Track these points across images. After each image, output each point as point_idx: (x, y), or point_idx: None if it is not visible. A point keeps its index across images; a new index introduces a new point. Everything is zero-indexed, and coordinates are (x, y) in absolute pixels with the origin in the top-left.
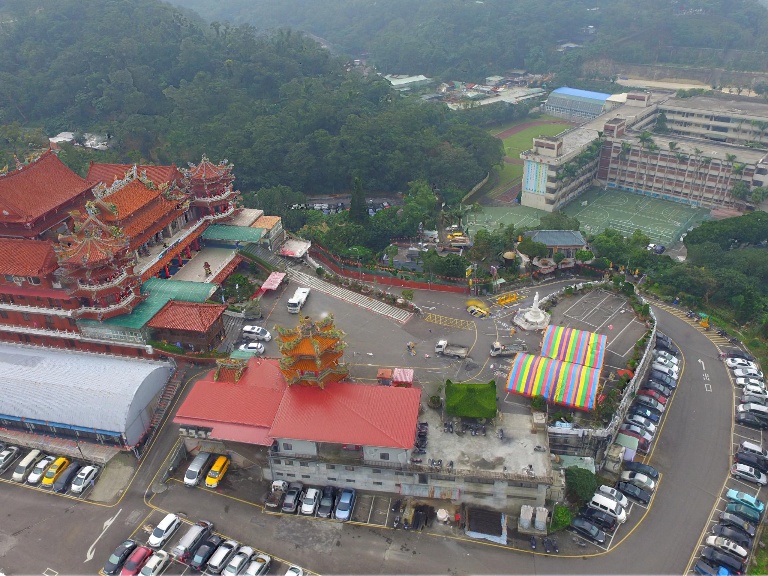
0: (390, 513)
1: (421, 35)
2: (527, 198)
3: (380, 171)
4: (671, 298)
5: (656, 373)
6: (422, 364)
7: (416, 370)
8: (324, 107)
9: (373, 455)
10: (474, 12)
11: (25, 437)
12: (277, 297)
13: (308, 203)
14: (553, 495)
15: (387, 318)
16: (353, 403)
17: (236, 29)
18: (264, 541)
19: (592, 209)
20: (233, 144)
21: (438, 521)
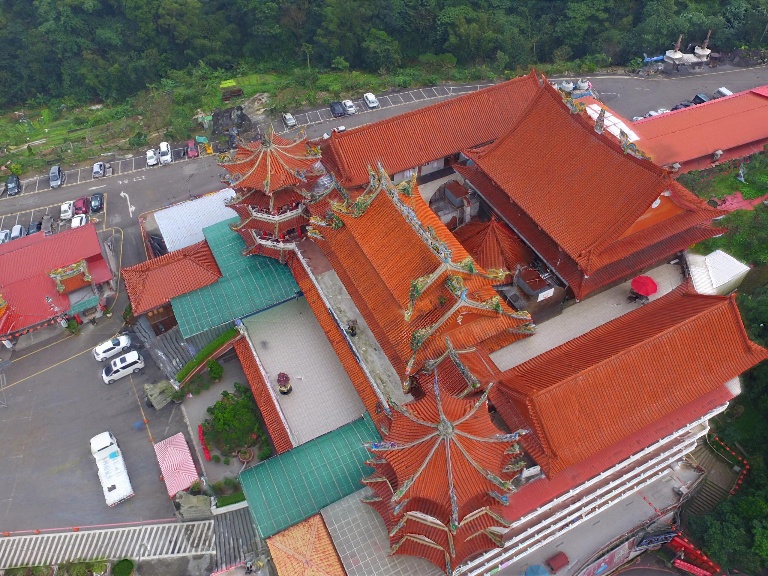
0: None
1: None
2: None
3: None
4: None
5: None
6: None
7: None
8: None
9: None
10: None
11: None
12: None
13: None
14: None
15: None
16: None
17: None
18: None
19: None
20: None
21: None
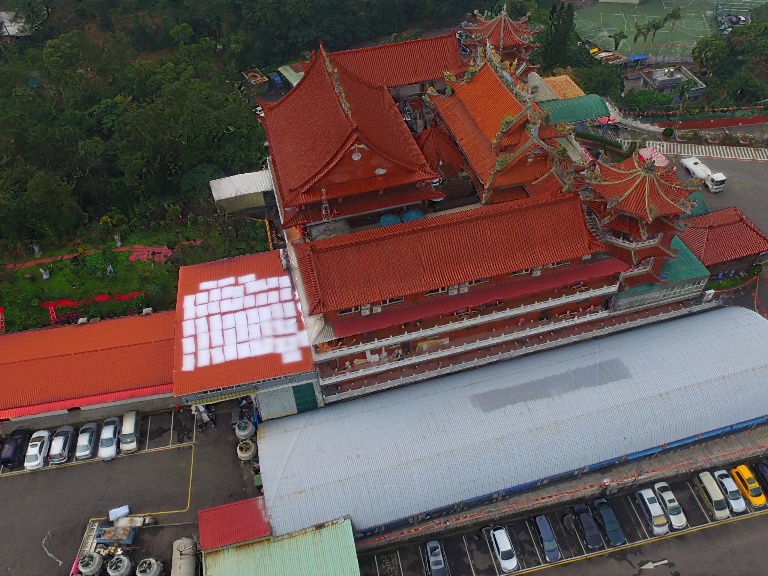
0: None
1: None
2: None
3: None
4: None
5: None
6: None
7: None
8: None
9: None
10: None
11: (654, 465)
12: None
13: None
14: None
15: None
16: None
17: None
18: None
19: None
20: None
21: None
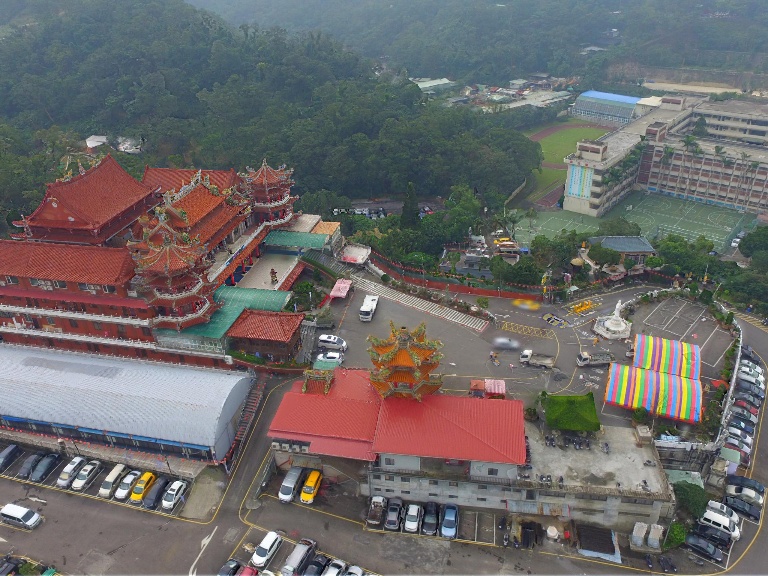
0: (497, 530)
1: (442, 38)
2: (570, 203)
3: (419, 175)
4: (744, 305)
5: (743, 383)
6: (509, 374)
7: (504, 381)
8: (362, 110)
9: (479, 470)
10: (496, 15)
11: (106, 451)
12: (346, 305)
13: (347, 208)
14: (662, 511)
15: (463, 326)
16: (454, 416)
17: (267, 32)
18: (371, 560)
19: (636, 214)
20: (271, 148)
21: (548, 539)
